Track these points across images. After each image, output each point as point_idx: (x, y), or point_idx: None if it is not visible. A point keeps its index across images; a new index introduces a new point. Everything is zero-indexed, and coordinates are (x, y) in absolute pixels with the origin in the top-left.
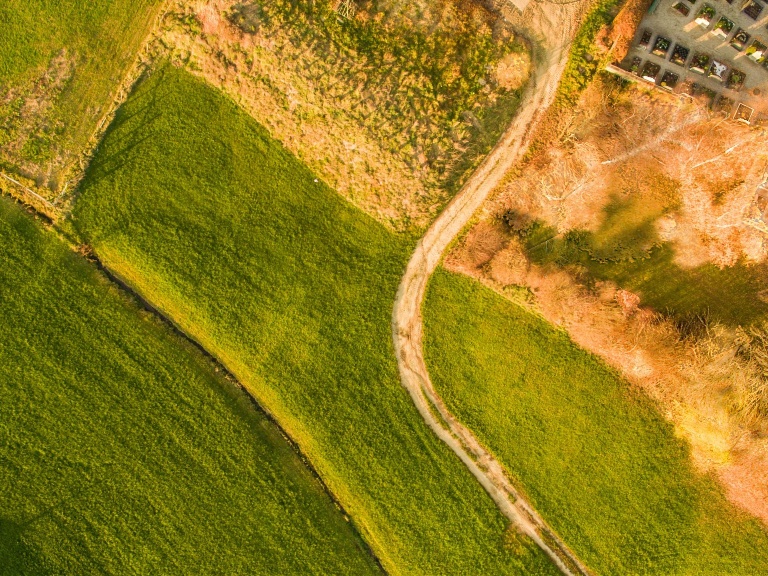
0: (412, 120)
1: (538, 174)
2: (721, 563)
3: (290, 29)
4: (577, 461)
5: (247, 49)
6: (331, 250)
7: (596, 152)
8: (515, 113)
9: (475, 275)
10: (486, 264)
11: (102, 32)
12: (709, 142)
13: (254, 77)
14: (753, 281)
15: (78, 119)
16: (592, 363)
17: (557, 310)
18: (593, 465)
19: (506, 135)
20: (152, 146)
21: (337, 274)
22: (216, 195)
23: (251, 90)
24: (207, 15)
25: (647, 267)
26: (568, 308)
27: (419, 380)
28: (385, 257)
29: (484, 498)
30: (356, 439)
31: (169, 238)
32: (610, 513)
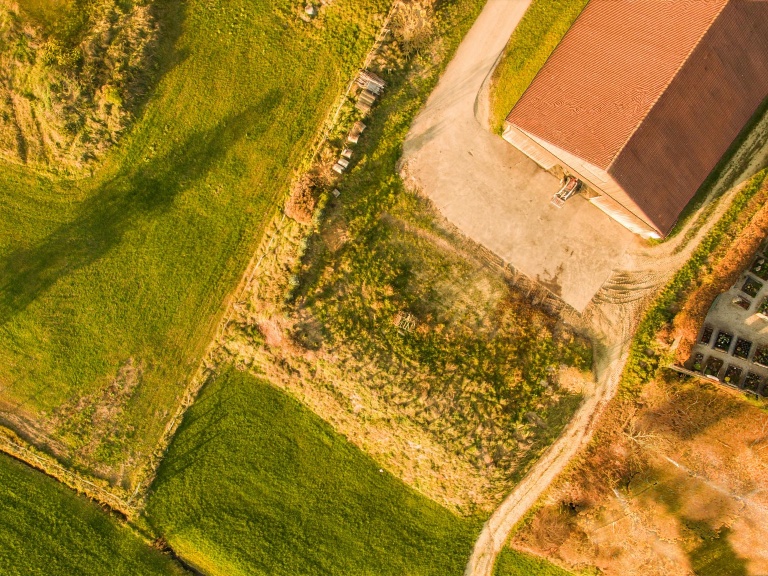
0: (476, 424)
1: (604, 468)
2: None
3: (352, 344)
4: None
5: (310, 361)
6: (399, 534)
7: (661, 444)
8: (577, 406)
9: (543, 555)
10: None
11: (167, 340)
12: None
13: (318, 383)
14: None
15: (147, 422)
16: None
17: None
18: None
19: (569, 426)
20: (220, 444)
21: (406, 556)
22: (284, 487)
23: (315, 393)
24: (269, 329)
25: (716, 546)
26: None
27: None
28: (452, 539)
29: None
30: None
31: (240, 529)
32: None
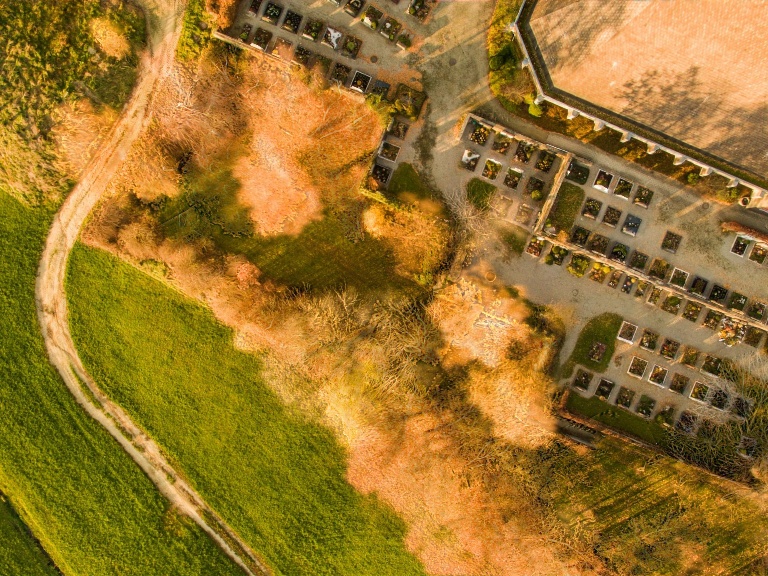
0: (22, 90)
1: (155, 145)
2: (388, 545)
3: None
4: (233, 441)
5: None
6: None
7: (214, 122)
8: (135, 83)
9: (112, 250)
10: (119, 239)
11: None
12: (336, 112)
13: None
14: (389, 255)
15: None
16: (239, 340)
17: (195, 285)
18: (250, 445)
19: (128, 106)
20: None
21: None
22: None
23: None
24: None
25: (280, 241)
26: (206, 283)
27: (68, 358)
28: (23, 232)
29: (141, 478)
30: (7, 418)
31: None
32: (272, 494)
